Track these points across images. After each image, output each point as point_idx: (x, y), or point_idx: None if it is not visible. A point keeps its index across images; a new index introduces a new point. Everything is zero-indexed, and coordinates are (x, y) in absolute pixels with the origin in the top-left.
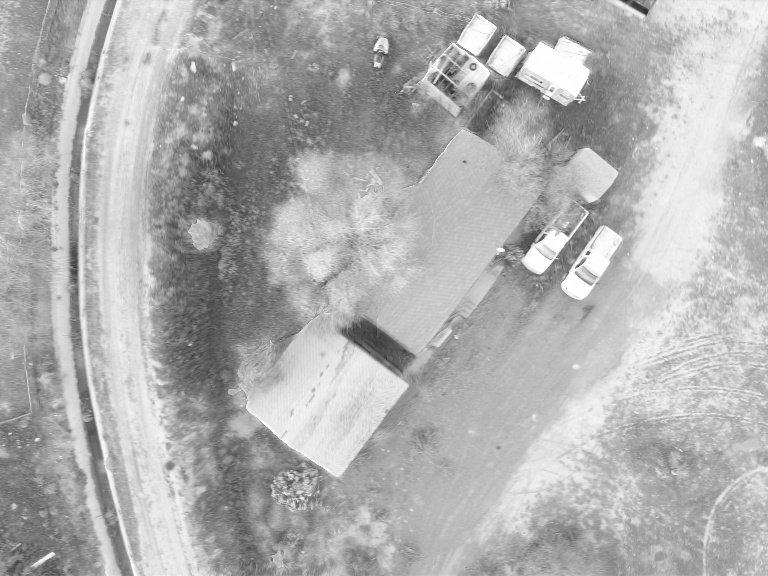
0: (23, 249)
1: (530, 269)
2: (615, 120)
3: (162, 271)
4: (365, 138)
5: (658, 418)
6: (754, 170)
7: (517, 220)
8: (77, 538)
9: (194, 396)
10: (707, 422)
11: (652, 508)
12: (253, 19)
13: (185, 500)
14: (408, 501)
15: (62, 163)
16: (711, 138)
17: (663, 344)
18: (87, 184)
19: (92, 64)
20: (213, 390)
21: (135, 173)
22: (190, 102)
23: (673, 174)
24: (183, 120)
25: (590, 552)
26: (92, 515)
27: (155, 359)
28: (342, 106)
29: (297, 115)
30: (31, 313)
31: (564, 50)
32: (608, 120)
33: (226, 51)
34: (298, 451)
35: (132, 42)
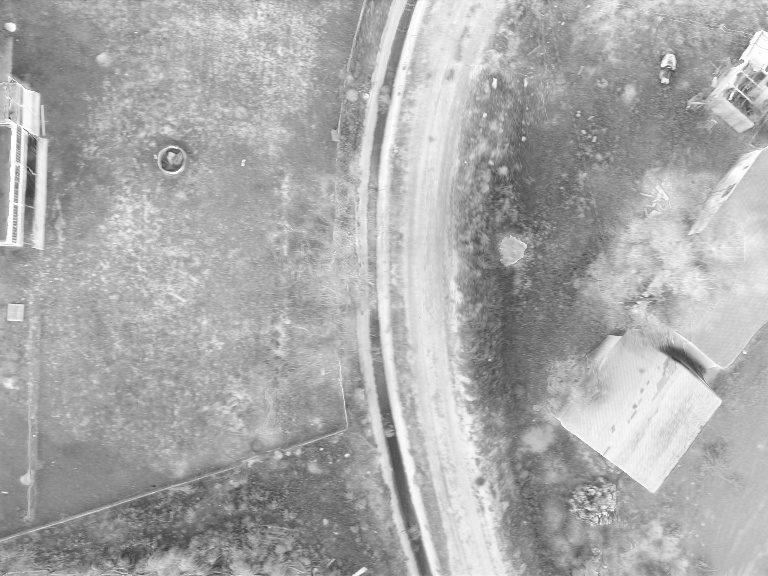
0: (347, 266)
1: None
2: None
3: (467, 287)
4: (651, 154)
5: None
6: None
7: None
8: (387, 553)
9: (495, 411)
10: None
11: None
12: (543, 35)
13: (495, 515)
14: (699, 515)
15: (363, 179)
16: None
17: None
18: (391, 200)
19: (388, 80)
20: (509, 405)
21: (440, 189)
22: (491, 118)
23: None
24: (485, 136)
25: None
26: (398, 530)
27: (464, 375)
28: (629, 122)
29: (585, 131)
30: (340, 329)
31: None
32: None
33: (521, 67)
34: (620, 467)
35: (435, 58)
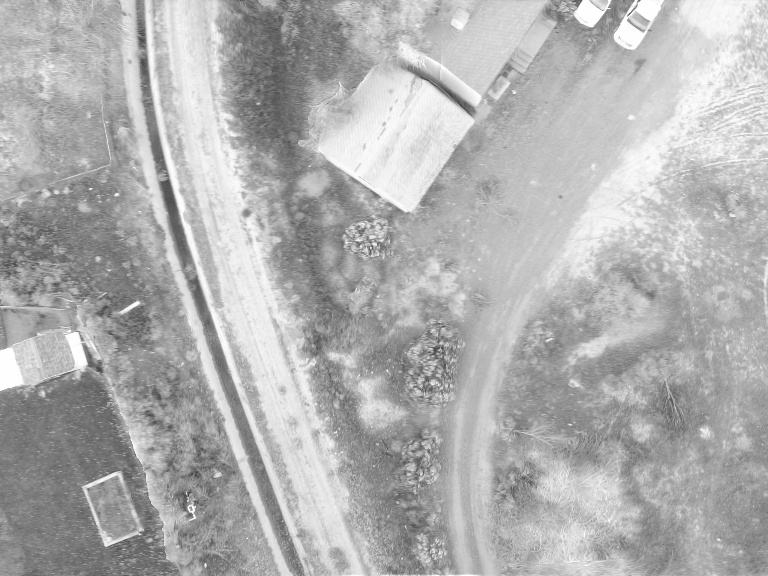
0: None
1: (583, 23)
2: None
3: (229, 30)
4: None
5: (713, 164)
6: None
7: None
8: (160, 288)
9: (265, 152)
10: (761, 167)
11: (712, 250)
12: None
13: (263, 246)
14: (475, 251)
15: None
16: None
17: (714, 94)
18: None
19: None
20: (282, 149)
21: None
22: None
23: None
24: None
25: (654, 293)
26: (172, 268)
27: (227, 112)
28: None
29: None
30: (105, 73)
31: None
32: None
33: None
34: (372, 183)
35: None
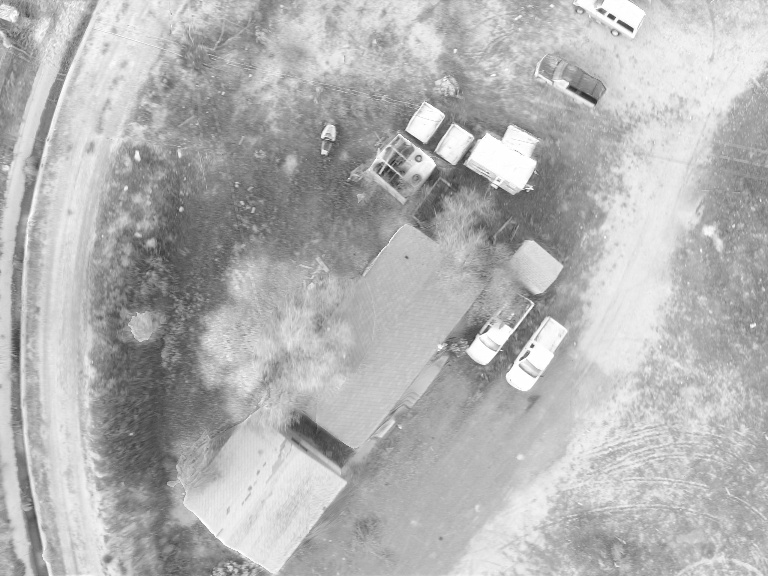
0: None
1: (475, 359)
2: (564, 208)
3: (103, 362)
4: (311, 225)
5: (602, 509)
6: (703, 260)
7: (459, 316)
8: None
9: (134, 486)
10: (651, 513)
11: None
12: (200, 105)
13: None
14: None
15: (5, 251)
16: (660, 227)
17: (608, 434)
18: (29, 273)
19: (37, 150)
20: (154, 479)
21: (77, 263)
22: (134, 191)
23: (621, 263)
24: (126, 209)
25: None
26: None
27: (94, 451)
28: (289, 193)
29: (243, 202)
30: None
31: (513, 138)
32: (557, 208)
33: (172, 138)
34: (234, 549)
35: (76, 131)
